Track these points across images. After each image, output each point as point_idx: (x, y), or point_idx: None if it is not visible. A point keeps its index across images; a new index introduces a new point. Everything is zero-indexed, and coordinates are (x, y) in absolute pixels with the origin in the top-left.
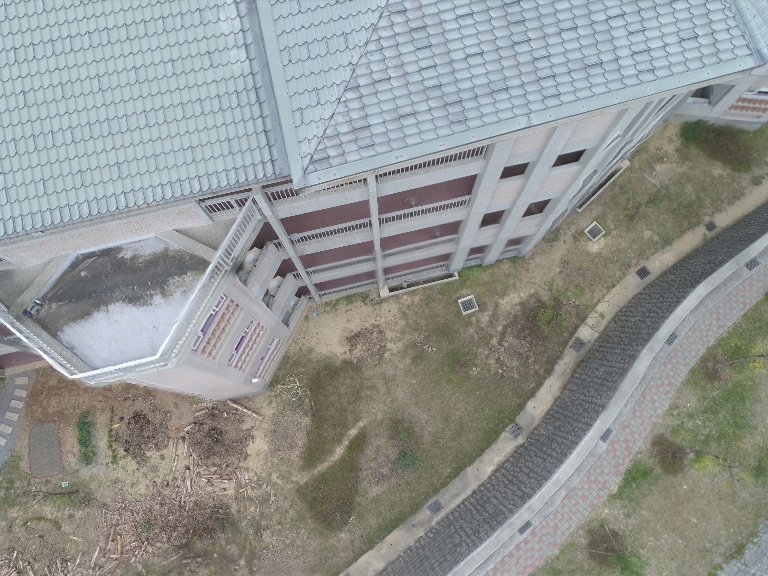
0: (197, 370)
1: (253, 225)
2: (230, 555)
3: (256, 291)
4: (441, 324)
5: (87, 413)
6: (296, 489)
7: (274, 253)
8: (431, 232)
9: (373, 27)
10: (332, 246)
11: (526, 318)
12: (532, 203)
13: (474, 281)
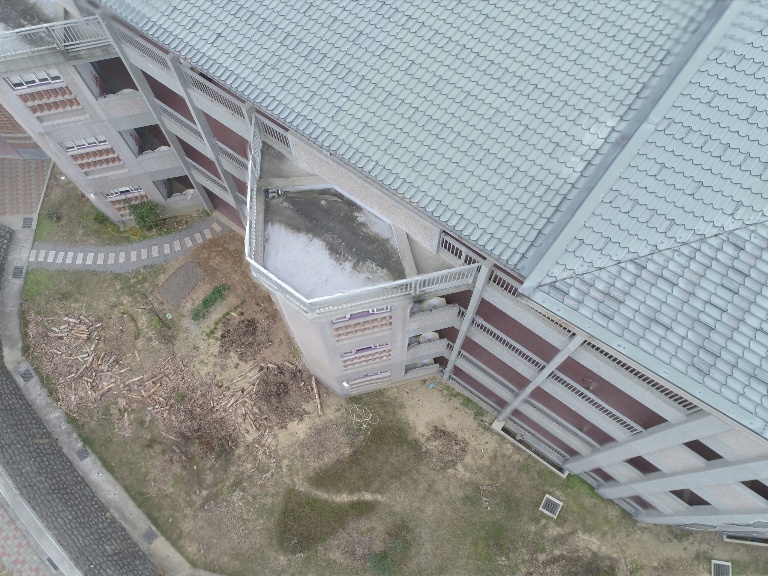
0: (320, 336)
1: (460, 283)
2: (203, 478)
3: (413, 327)
4: (514, 496)
5: (228, 287)
6: (289, 488)
7: (452, 315)
8: (582, 422)
9: (702, 237)
10: (497, 354)
11: (587, 570)
12: (690, 490)
13: (575, 494)
